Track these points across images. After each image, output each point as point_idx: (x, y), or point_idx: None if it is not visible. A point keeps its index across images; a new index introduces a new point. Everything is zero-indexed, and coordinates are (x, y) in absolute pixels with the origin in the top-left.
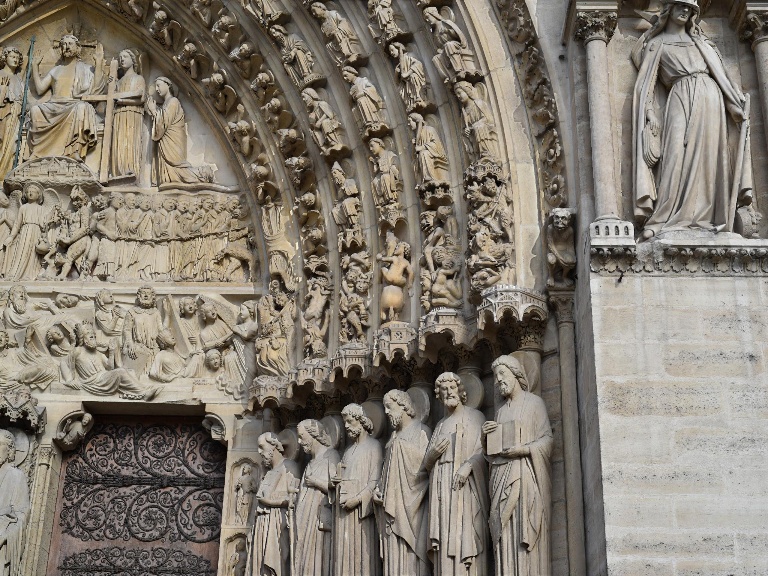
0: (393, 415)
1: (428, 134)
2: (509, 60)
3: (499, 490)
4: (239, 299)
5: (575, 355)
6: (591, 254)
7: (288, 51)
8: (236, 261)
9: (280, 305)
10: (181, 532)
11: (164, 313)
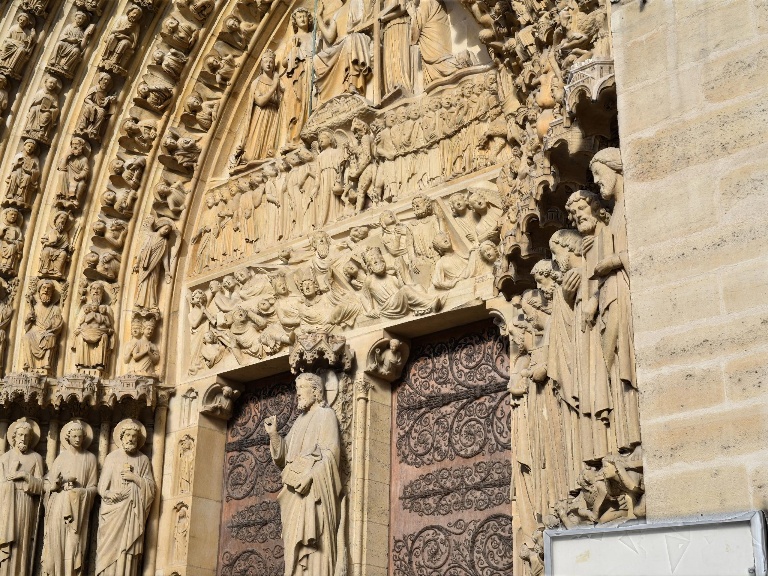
0: (558, 261)
1: None
2: None
3: None
4: None
5: None
6: None
7: None
8: (499, 140)
9: (515, 173)
10: (497, 442)
11: None
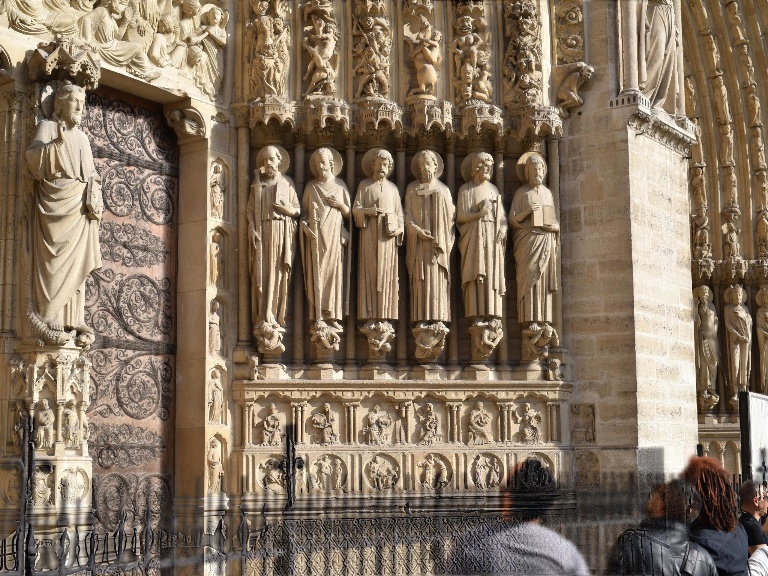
0: (431, 171)
1: None
2: None
3: (540, 251)
4: None
5: (559, 164)
6: None
7: None
8: None
9: (280, 30)
10: (145, 212)
11: None
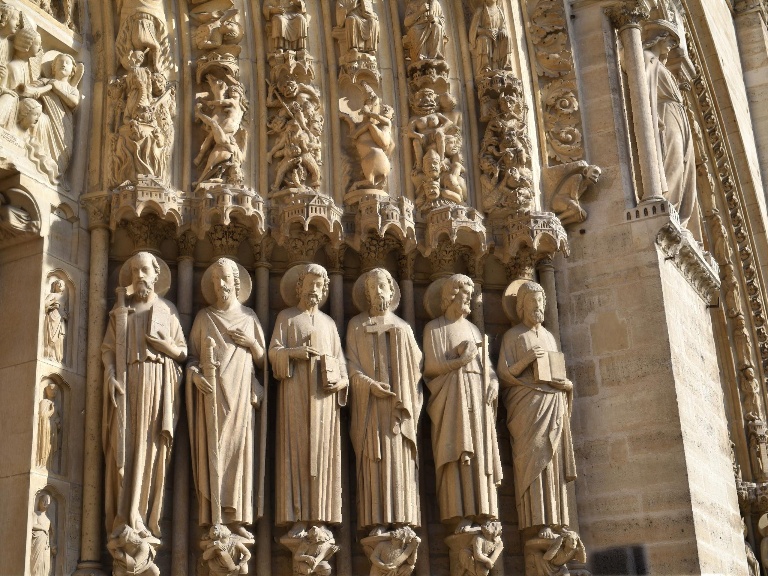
0: (386, 298)
1: (438, 7)
2: None
3: (549, 418)
4: (46, 42)
5: None
6: (663, 227)
7: None
8: None
9: (161, 90)
10: None
11: None
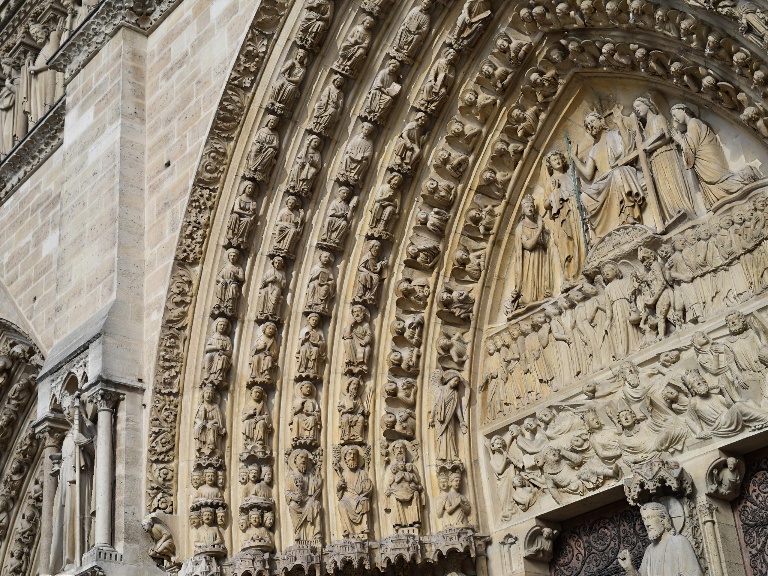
0: None
1: None
2: None
3: None
4: None
5: None
6: None
7: None
8: None
9: None
10: None
11: (758, 331)
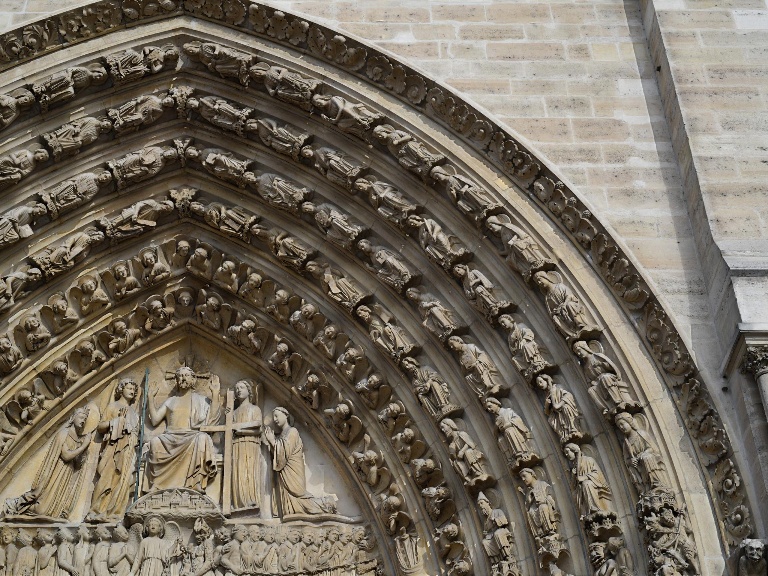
0: None
1: (588, 464)
2: (666, 392)
3: None
4: None
5: None
6: None
7: (422, 382)
8: None
9: None
10: None
11: None
